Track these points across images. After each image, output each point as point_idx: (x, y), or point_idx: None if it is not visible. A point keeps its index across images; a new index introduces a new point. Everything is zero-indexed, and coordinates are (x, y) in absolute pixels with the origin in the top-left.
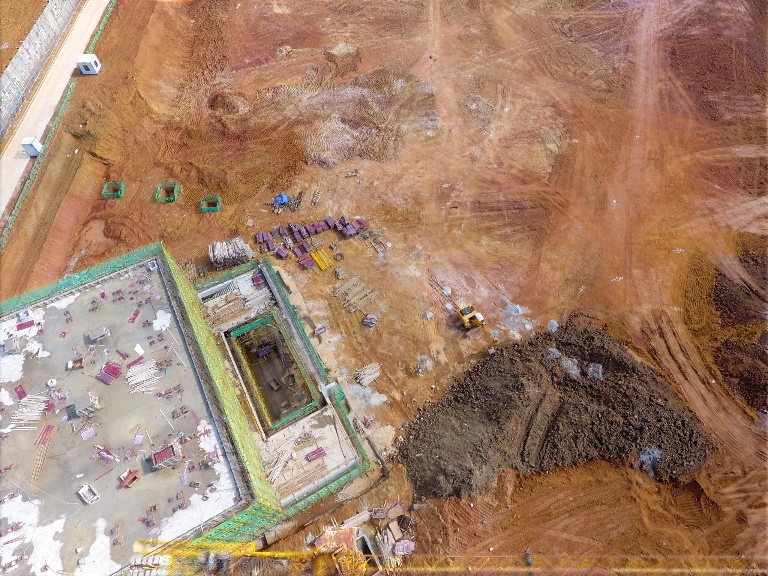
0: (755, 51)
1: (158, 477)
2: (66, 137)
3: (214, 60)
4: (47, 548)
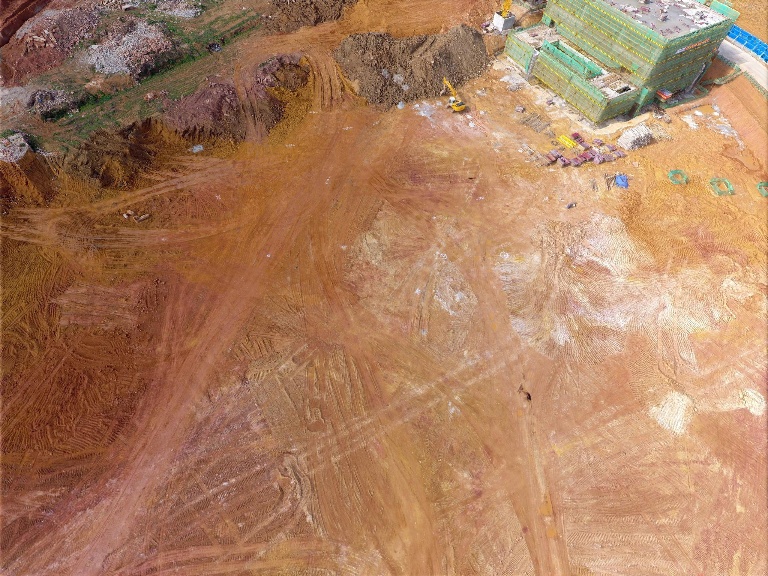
0: None
1: None
2: None
3: None
4: None
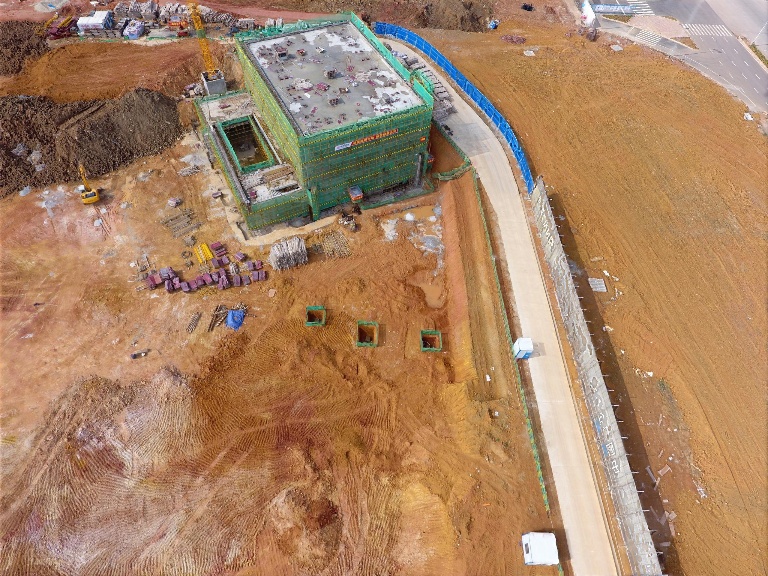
0: None
1: None
2: (505, 390)
3: None
4: (334, 40)
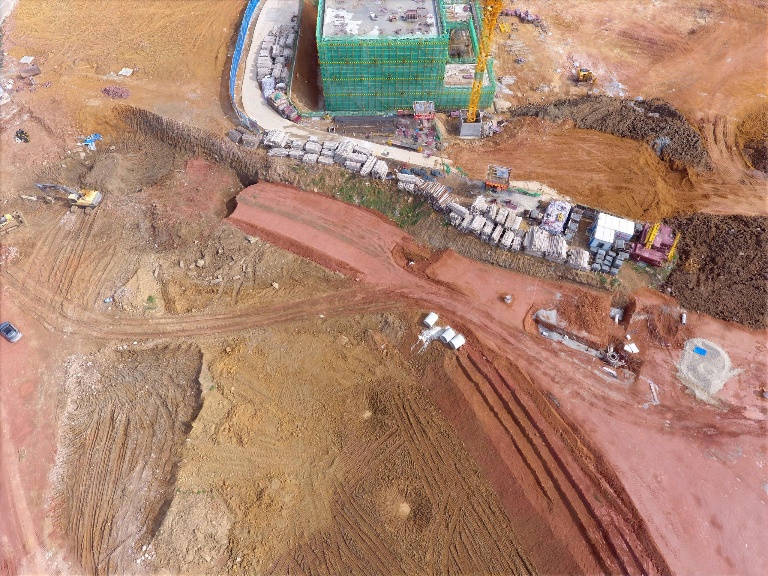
0: None
1: (405, 23)
2: None
3: None
4: (353, 26)
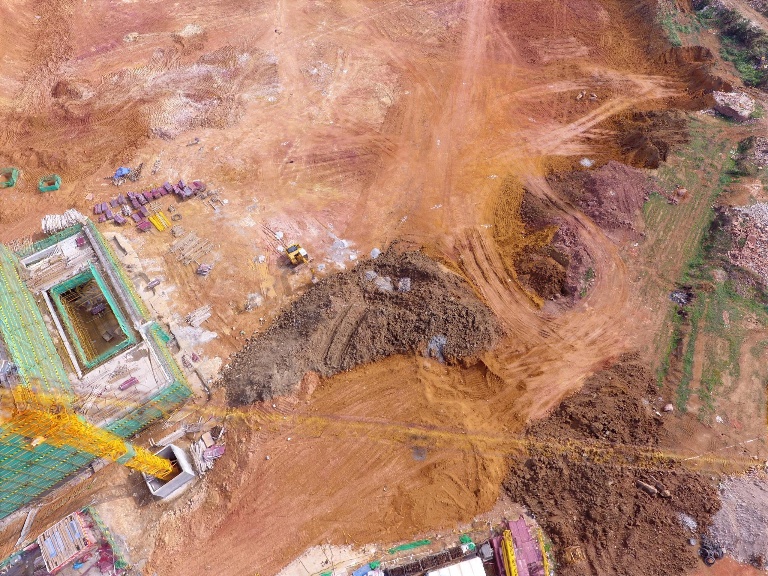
0: (574, 0)
1: None
2: None
3: (59, 52)
4: None
